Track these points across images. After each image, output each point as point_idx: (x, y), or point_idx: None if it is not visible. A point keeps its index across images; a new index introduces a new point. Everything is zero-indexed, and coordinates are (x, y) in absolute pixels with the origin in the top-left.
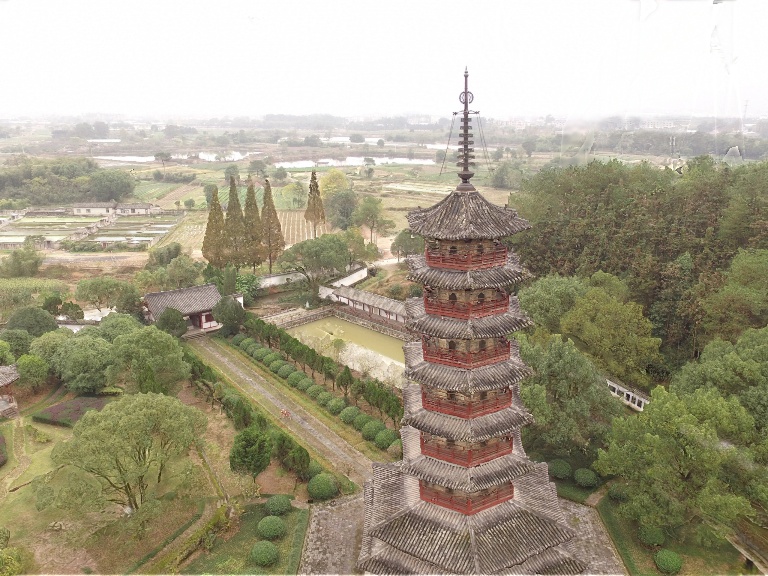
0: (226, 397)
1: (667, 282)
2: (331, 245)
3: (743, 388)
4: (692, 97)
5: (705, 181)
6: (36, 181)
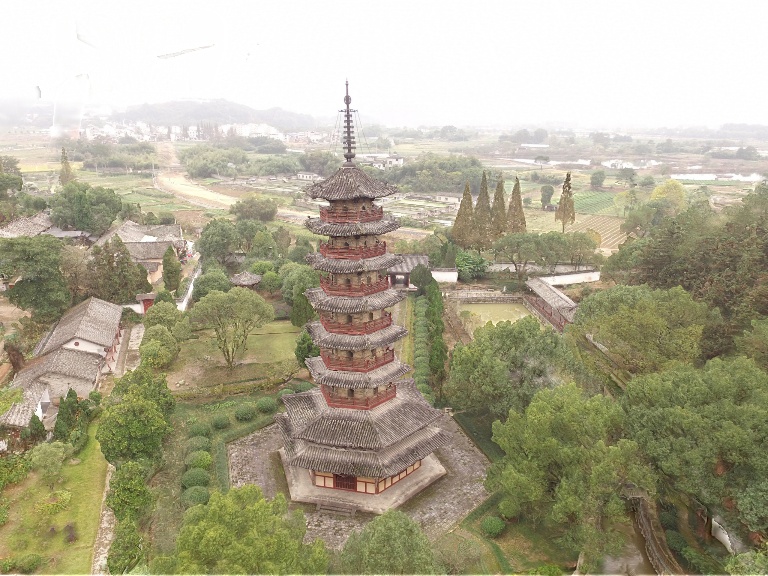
0: None
1: None
2: (538, 239)
3: None
4: None
5: None
6: (423, 173)
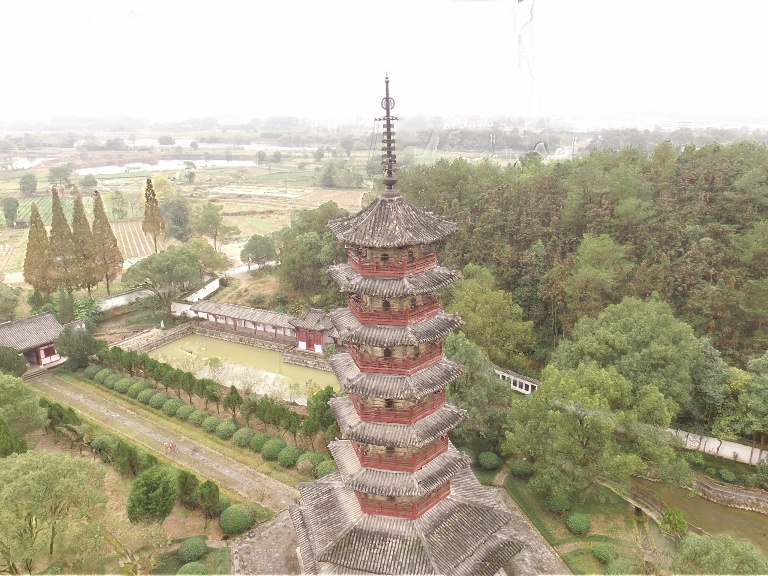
0: (96, 440)
1: (526, 269)
2: (182, 258)
3: (614, 358)
4: (507, 99)
5: (544, 175)
6: None
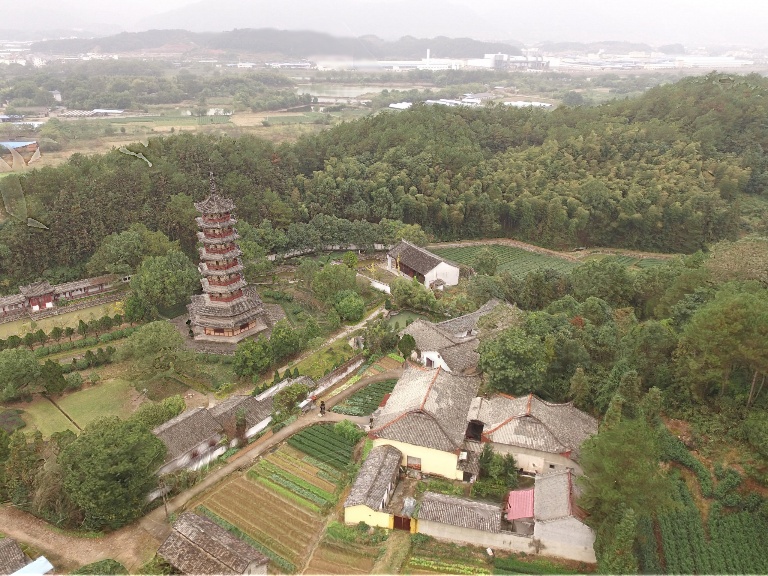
0: None
1: None
2: None
3: None
4: None
5: (118, 169)
6: None
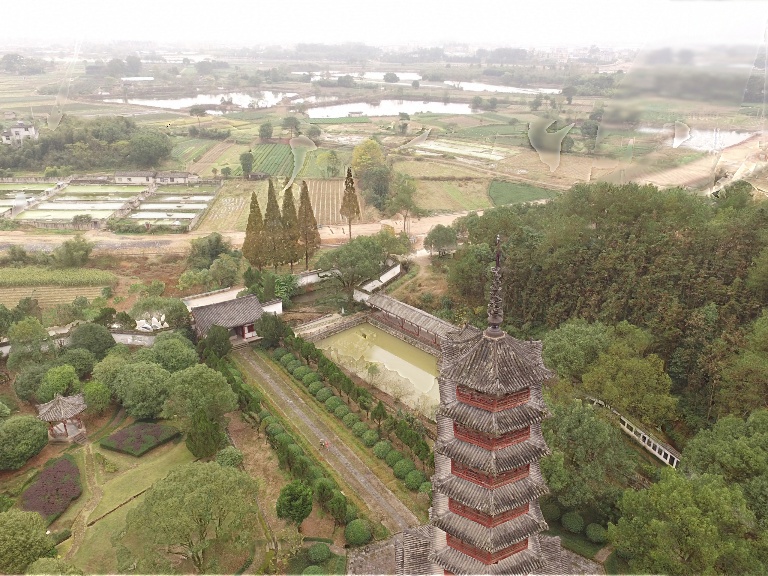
0: (270, 427)
1: (691, 331)
2: (366, 253)
3: None
4: (740, 89)
5: (739, 224)
6: (78, 146)
